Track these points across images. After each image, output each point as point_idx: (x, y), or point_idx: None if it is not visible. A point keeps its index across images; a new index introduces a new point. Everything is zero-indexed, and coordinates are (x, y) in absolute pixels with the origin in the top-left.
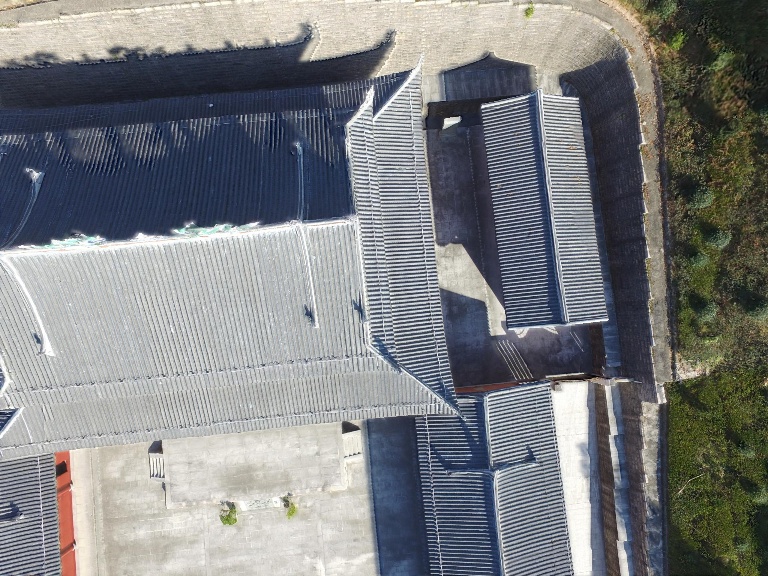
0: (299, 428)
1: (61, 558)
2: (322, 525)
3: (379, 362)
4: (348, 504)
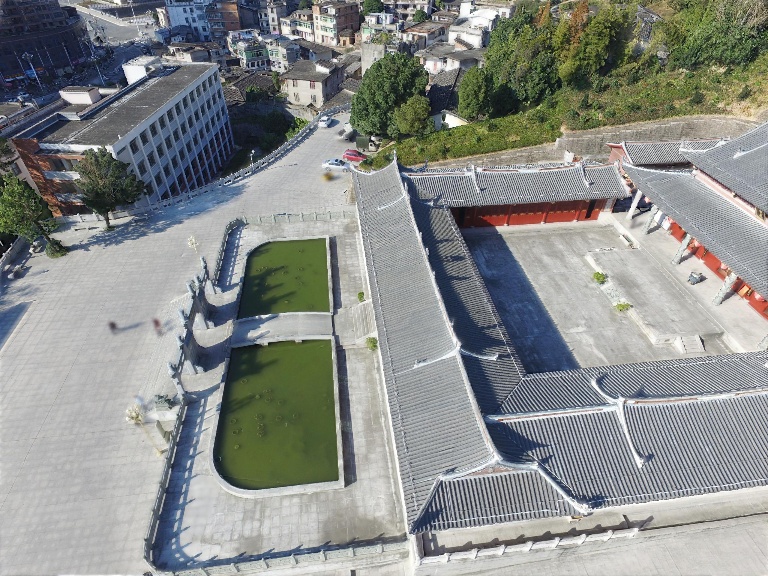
0: (684, 310)
1: (544, 214)
2: (613, 330)
3: None
4: (639, 345)
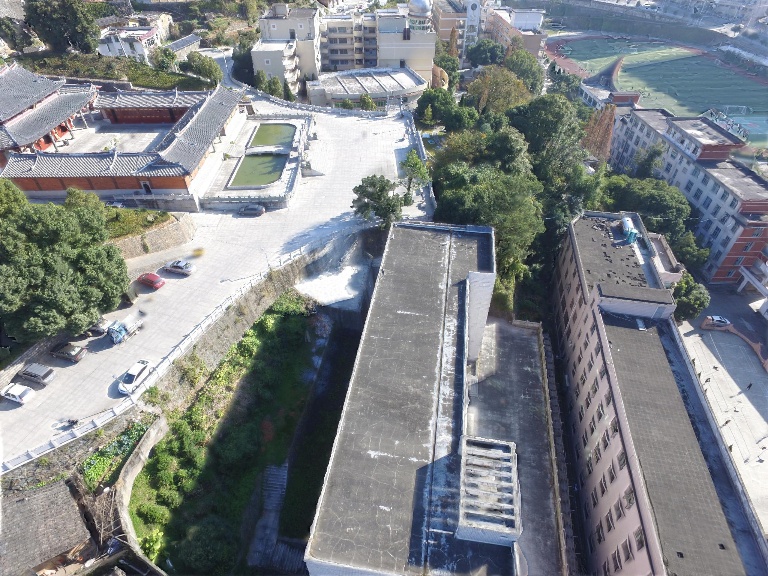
0: None
1: None
2: None
3: (61, 83)
4: None
